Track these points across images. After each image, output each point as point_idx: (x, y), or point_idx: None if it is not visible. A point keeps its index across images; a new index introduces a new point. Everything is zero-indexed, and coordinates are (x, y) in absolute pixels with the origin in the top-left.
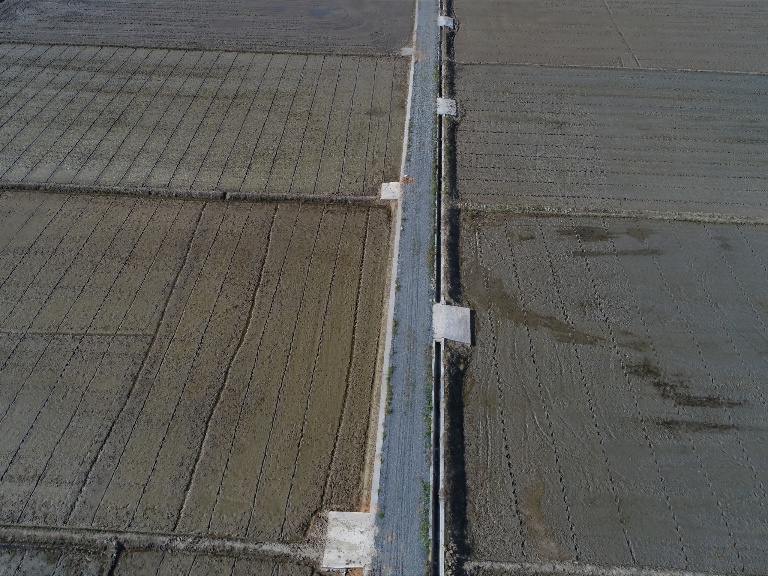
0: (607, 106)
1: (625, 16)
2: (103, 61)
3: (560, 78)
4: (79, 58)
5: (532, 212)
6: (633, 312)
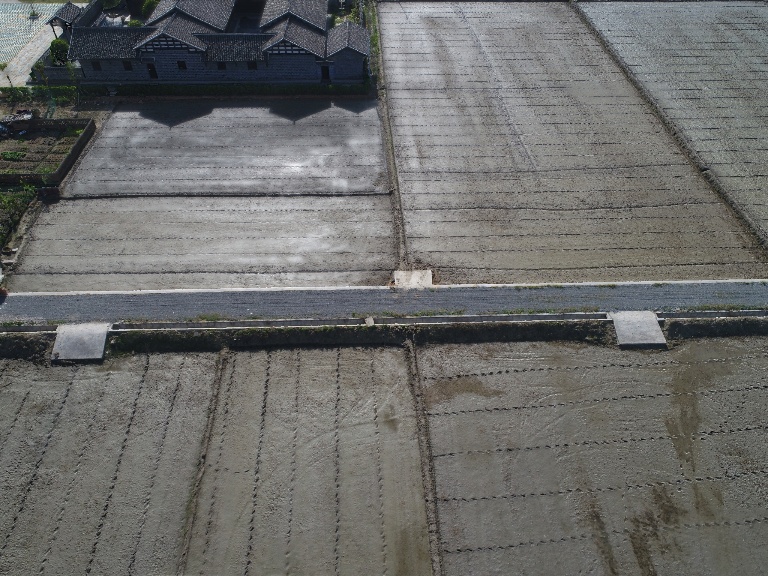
0: None
1: None
2: None
3: None
4: None
5: None
6: (764, 511)
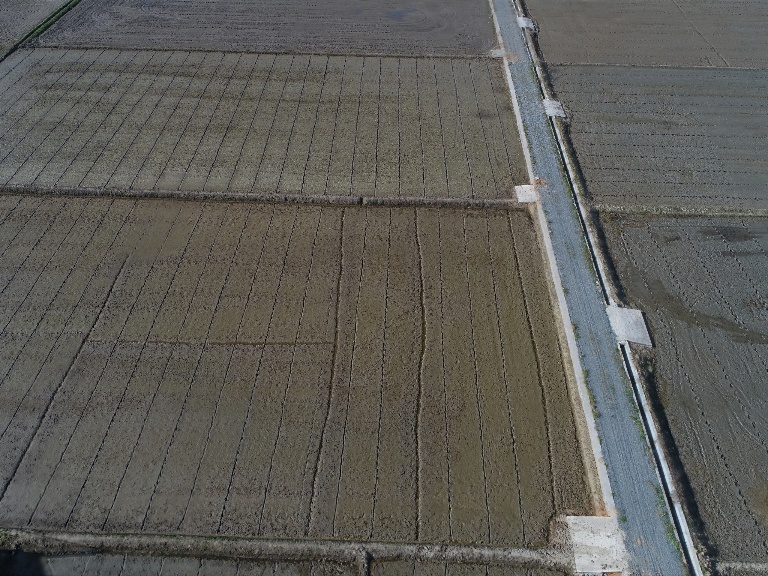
0: (709, 106)
1: (698, 15)
2: (196, 66)
3: (654, 78)
4: (171, 63)
5: (670, 213)
6: None
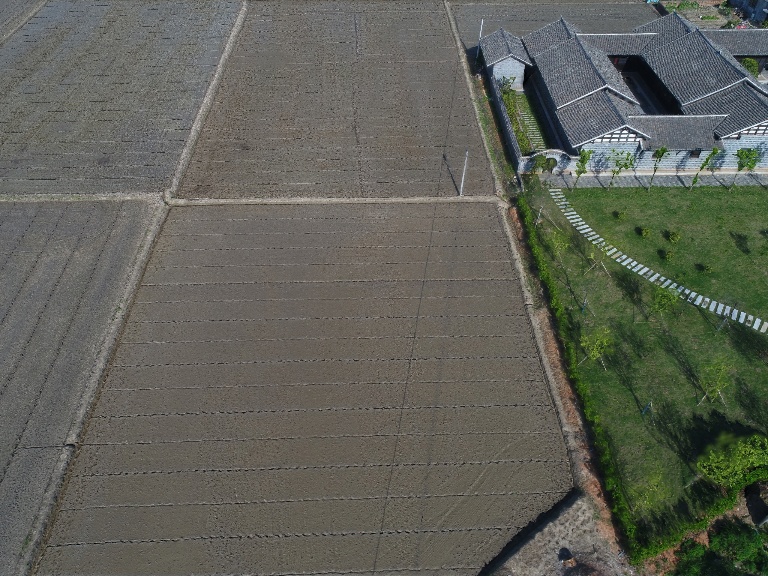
0: None
1: None
2: None
3: None
4: None
5: None
6: None
